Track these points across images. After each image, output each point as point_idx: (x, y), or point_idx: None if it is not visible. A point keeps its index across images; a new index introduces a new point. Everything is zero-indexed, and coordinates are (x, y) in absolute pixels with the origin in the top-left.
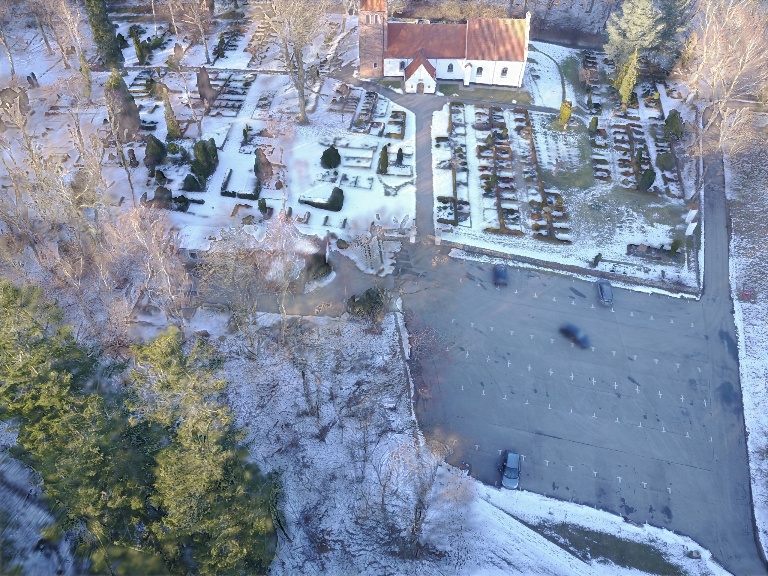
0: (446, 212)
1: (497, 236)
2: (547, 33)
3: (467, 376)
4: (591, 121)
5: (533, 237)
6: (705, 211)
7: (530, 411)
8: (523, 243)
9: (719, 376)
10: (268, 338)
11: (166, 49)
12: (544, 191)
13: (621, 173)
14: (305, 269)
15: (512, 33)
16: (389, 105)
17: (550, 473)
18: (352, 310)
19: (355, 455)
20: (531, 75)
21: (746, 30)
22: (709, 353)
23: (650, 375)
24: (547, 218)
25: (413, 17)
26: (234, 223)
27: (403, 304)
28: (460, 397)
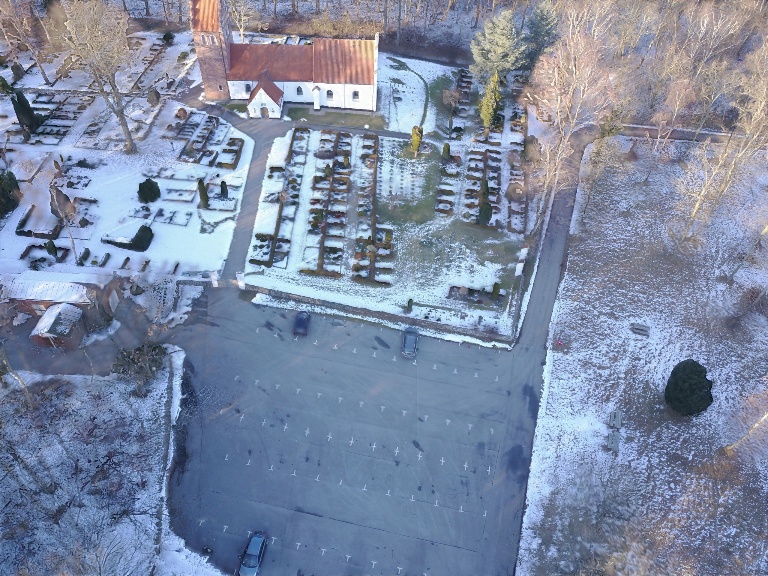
0: (261, 252)
1: (312, 278)
2: (425, 50)
3: (235, 443)
4: (443, 148)
5: (351, 279)
6: (543, 247)
7: (295, 484)
8: (338, 286)
9: (511, 438)
10: (17, 403)
11: (8, 68)
12: (375, 227)
13: (465, 205)
14: (80, 321)
15: (360, 55)
16: (229, 131)
17: (298, 558)
18: (115, 370)
19: (86, 541)
20: (393, 97)
21: (588, 56)
22: (507, 411)
23: (437, 438)
24: (370, 257)
25: (284, 33)
26: (20, 267)
27: (185, 359)
28: (221, 468)
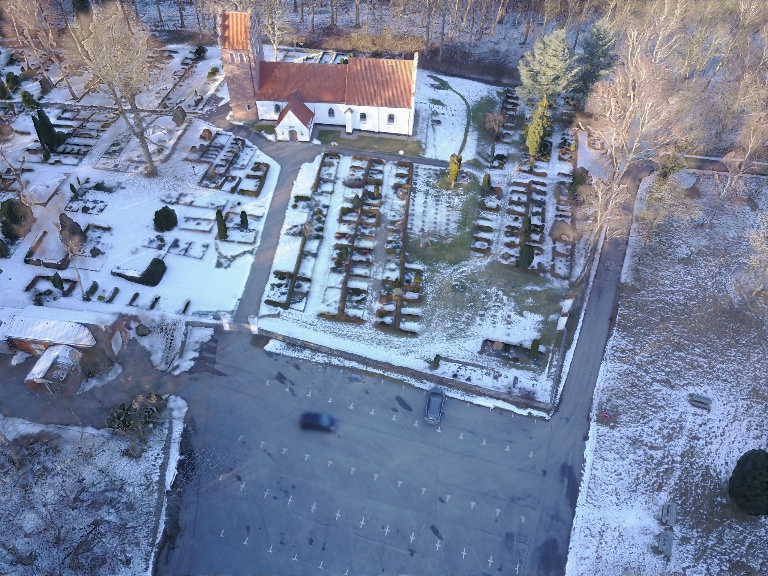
0: (278, 291)
1: (331, 324)
2: (469, 68)
3: (233, 517)
4: (483, 179)
5: (373, 326)
6: (590, 297)
7: (295, 570)
8: (359, 334)
9: (545, 530)
10: (4, 457)
11: (38, 81)
12: (403, 266)
13: (504, 244)
14: None
15: (397, 76)
16: (255, 154)
17: None
18: (109, 426)
19: None
20: (431, 120)
21: (649, 84)
22: (541, 496)
23: (459, 525)
24: (397, 302)
25: (321, 48)
26: (25, 300)
27: (187, 413)
28: (215, 546)
